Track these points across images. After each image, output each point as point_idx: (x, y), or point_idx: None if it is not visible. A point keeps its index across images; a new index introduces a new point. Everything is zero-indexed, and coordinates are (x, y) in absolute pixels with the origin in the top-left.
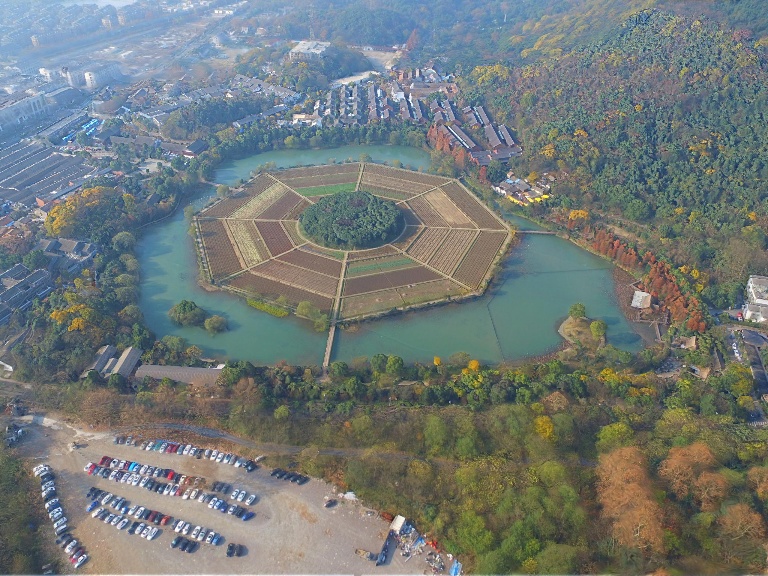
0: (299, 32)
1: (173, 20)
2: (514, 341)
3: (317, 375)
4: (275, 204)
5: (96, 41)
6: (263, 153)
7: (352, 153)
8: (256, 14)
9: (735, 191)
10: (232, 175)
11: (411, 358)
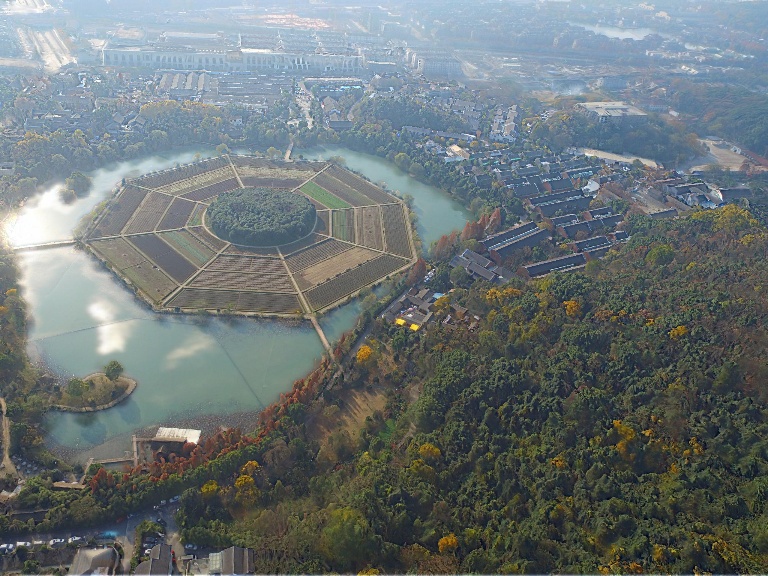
0: (690, 105)
1: (617, 59)
2: (75, 344)
3: (1, 246)
4: (274, 179)
5: (515, 51)
6: (375, 155)
7: (424, 194)
8: (713, 81)
9: (532, 512)
10: (317, 153)
11: (34, 286)
